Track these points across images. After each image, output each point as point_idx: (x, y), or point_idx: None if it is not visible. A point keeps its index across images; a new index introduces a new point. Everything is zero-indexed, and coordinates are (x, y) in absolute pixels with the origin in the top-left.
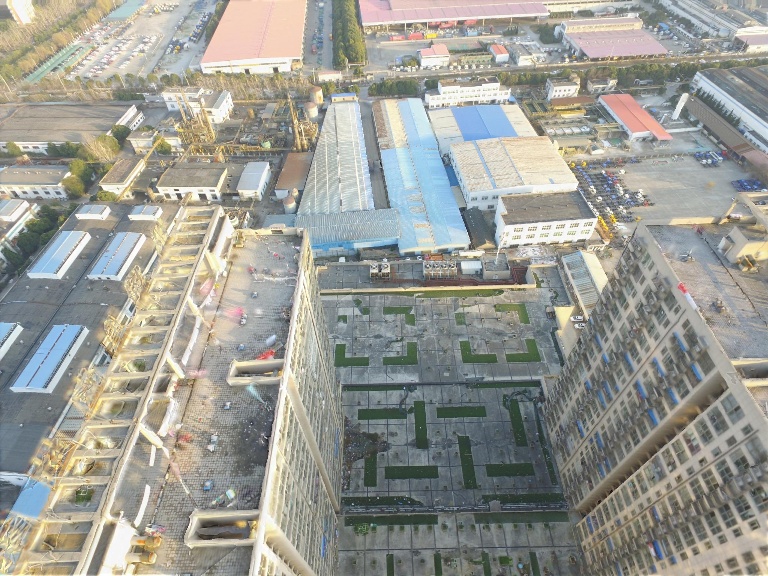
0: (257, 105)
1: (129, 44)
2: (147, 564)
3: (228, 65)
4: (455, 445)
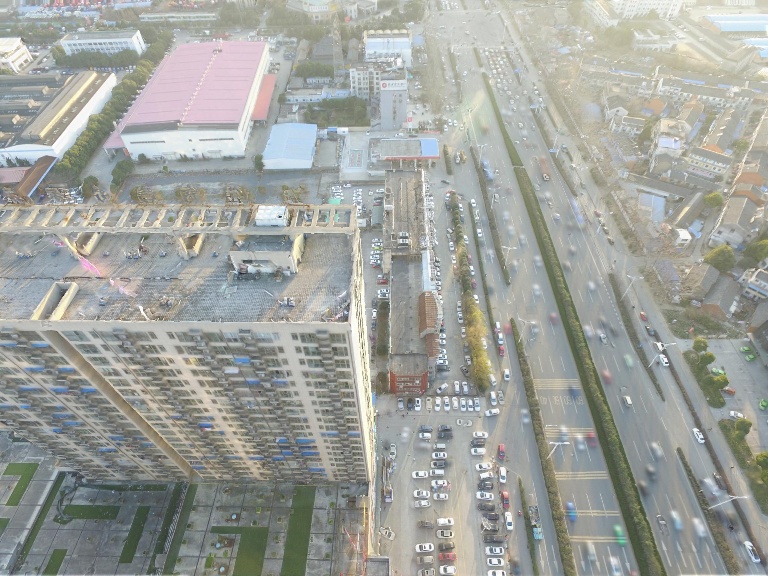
0: None
1: None
2: None
3: None
4: None
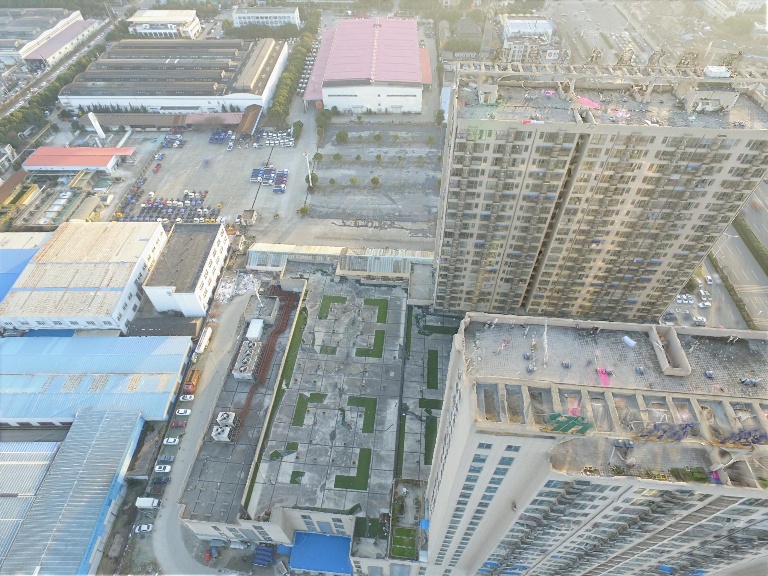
0: None
1: None
2: None
3: None
4: None
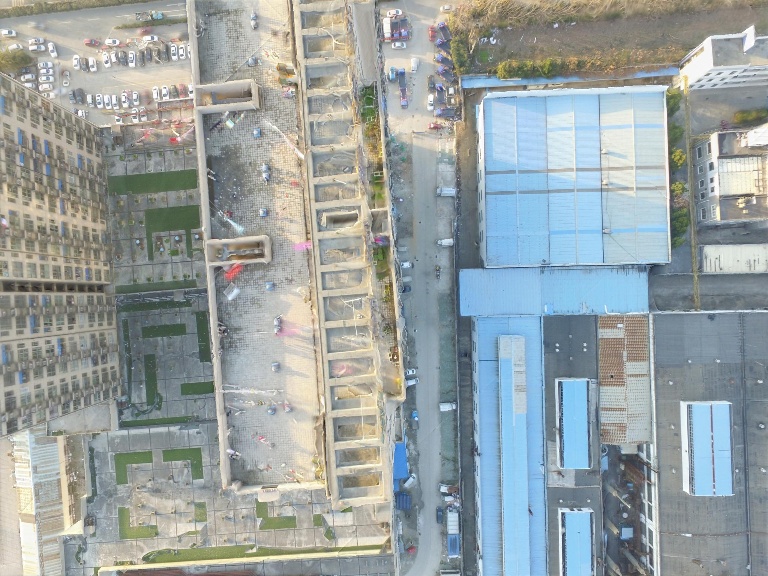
0: None
1: None
2: None
3: None
4: None
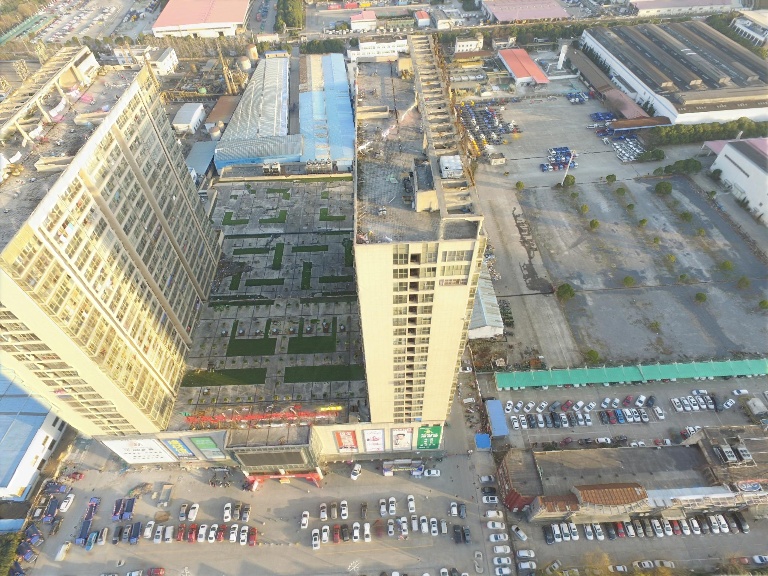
0: (200, 62)
1: (90, 14)
2: (15, 176)
3: (177, 29)
4: (300, 267)
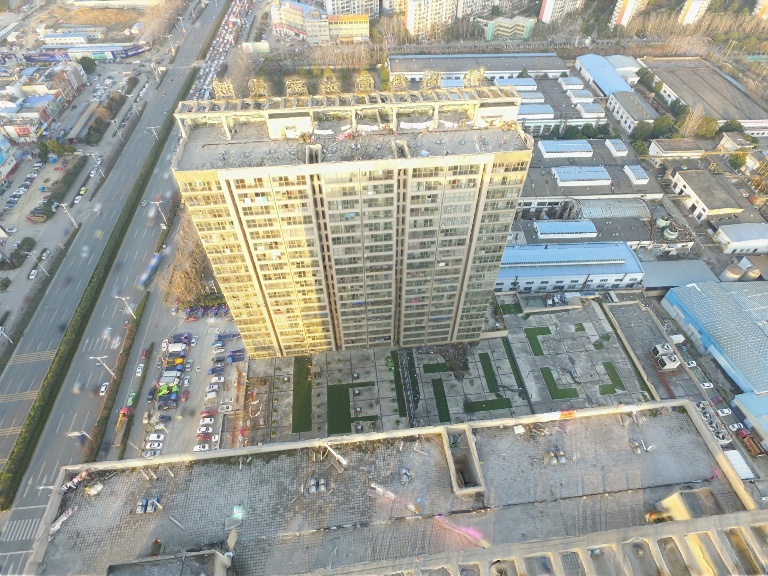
0: None
1: None
2: None
3: None
4: None
